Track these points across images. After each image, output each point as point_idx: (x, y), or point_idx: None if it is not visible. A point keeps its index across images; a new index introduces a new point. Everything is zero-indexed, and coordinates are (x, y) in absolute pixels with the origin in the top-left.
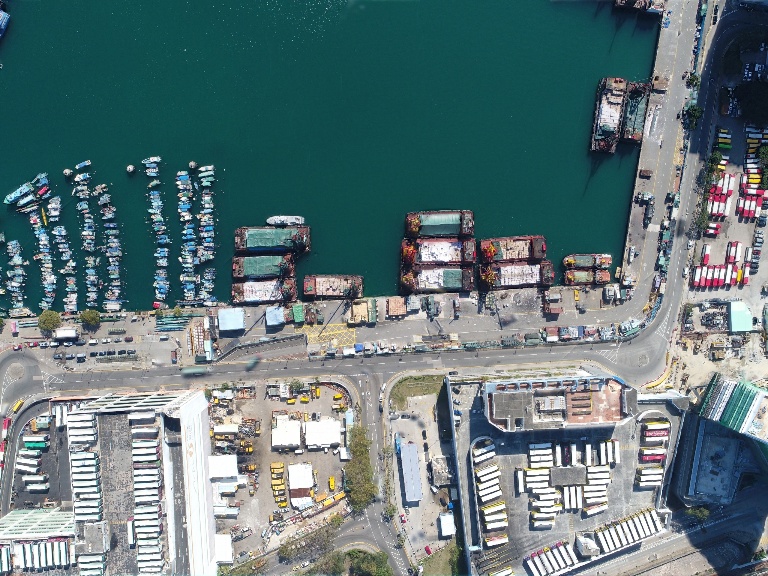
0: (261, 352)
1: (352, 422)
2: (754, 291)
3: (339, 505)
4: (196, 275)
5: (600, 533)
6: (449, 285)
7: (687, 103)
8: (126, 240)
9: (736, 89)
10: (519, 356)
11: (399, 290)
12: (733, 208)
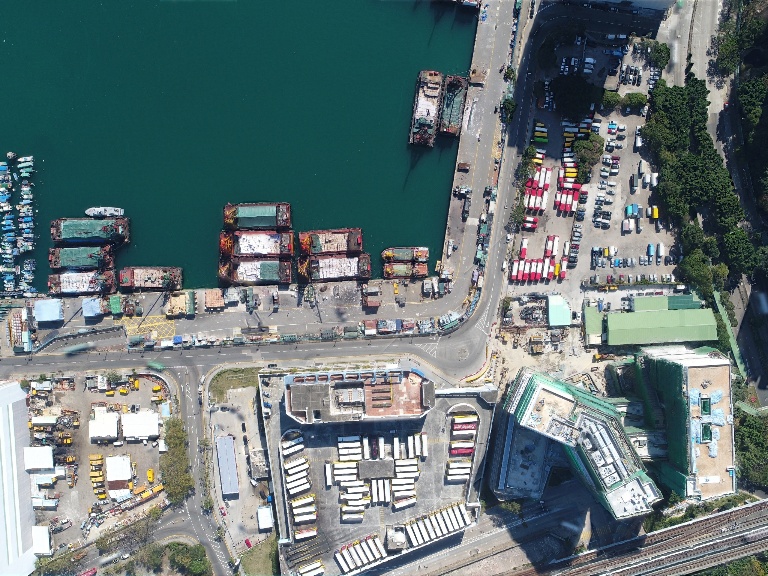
0: (80, 343)
1: (168, 414)
2: (573, 285)
3: (159, 497)
4: (16, 266)
5: (408, 526)
6: (266, 277)
7: (505, 97)
8: None
9: (551, 83)
10: (338, 349)
11: (218, 282)
12: (551, 202)
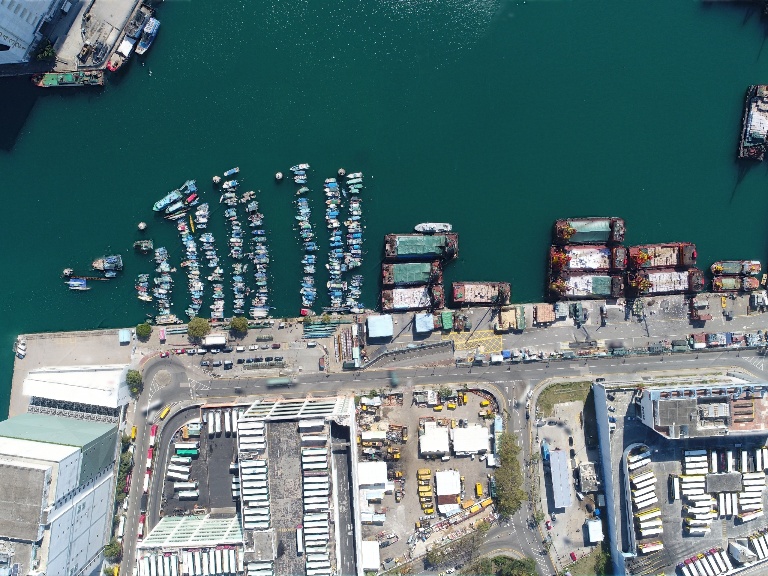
0: (408, 359)
1: (501, 429)
2: None
3: (485, 511)
4: (343, 282)
5: (755, 540)
6: (598, 292)
7: None
8: (273, 247)
9: None
10: (666, 363)
11: (546, 297)
12: None
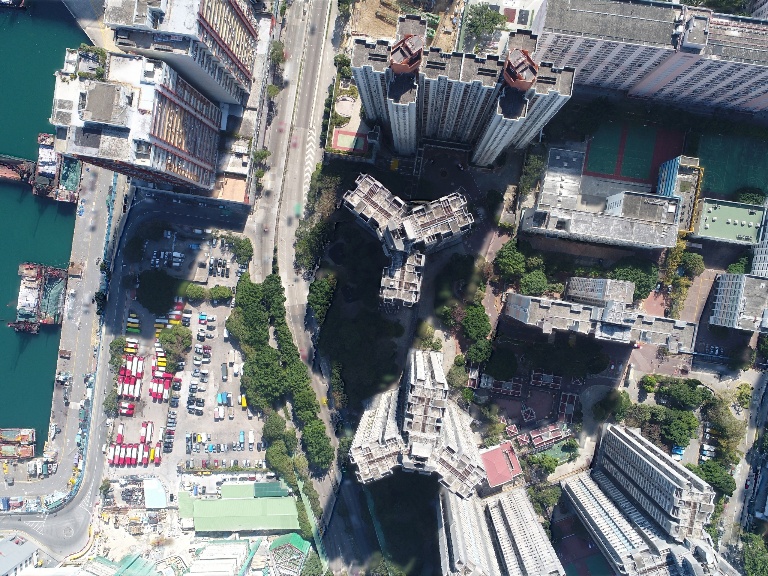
0: None
1: None
2: (170, 469)
3: None
4: None
5: None
6: None
7: None
8: None
9: (139, 277)
10: None
11: None
12: (147, 388)
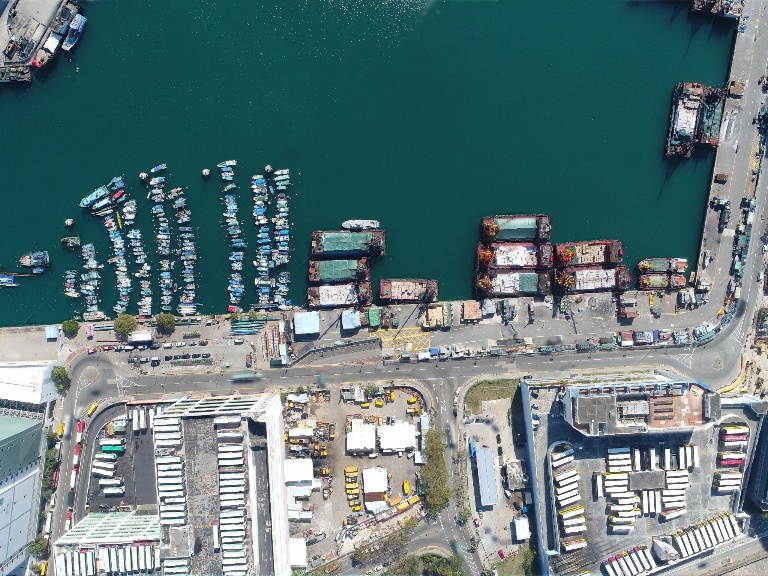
0: (336, 356)
1: (427, 426)
2: None
3: (413, 509)
4: (271, 279)
5: (678, 537)
6: (525, 289)
7: (763, 108)
8: (201, 244)
9: None
10: (594, 360)
11: (474, 294)
12: None
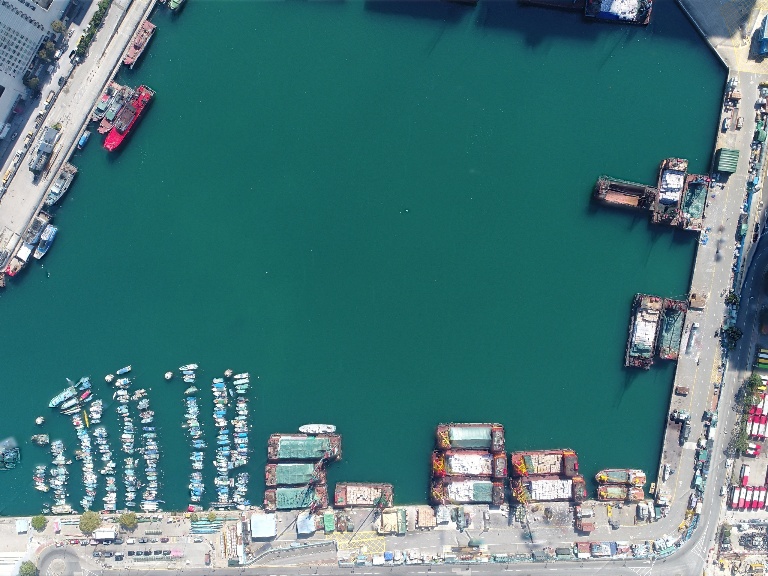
0: (292, 557)
1: None
2: None
3: None
4: (230, 479)
5: None
6: (479, 499)
7: (726, 321)
8: (163, 443)
9: None
10: (550, 570)
11: (429, 500)
12: None
